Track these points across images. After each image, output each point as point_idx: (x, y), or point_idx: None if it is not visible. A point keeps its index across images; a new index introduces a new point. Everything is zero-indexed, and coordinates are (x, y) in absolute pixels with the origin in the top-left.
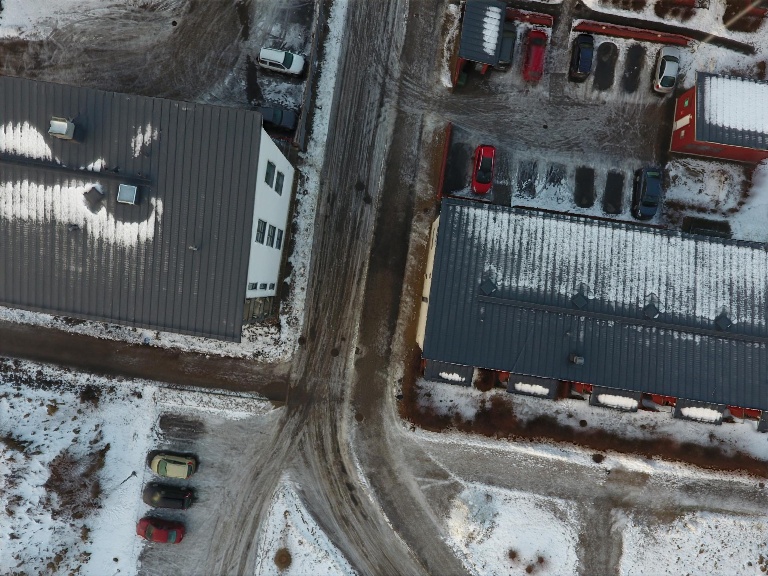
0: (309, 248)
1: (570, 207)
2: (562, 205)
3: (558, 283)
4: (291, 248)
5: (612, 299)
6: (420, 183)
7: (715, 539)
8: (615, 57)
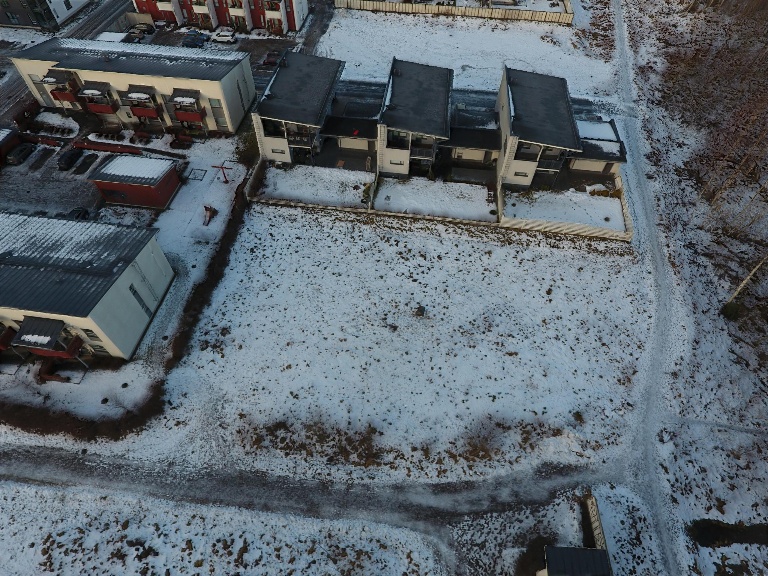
0: None
1: None
2: None
3: None
4: None
5: None
6: None
7: (5, 514)
8: (95, 160)
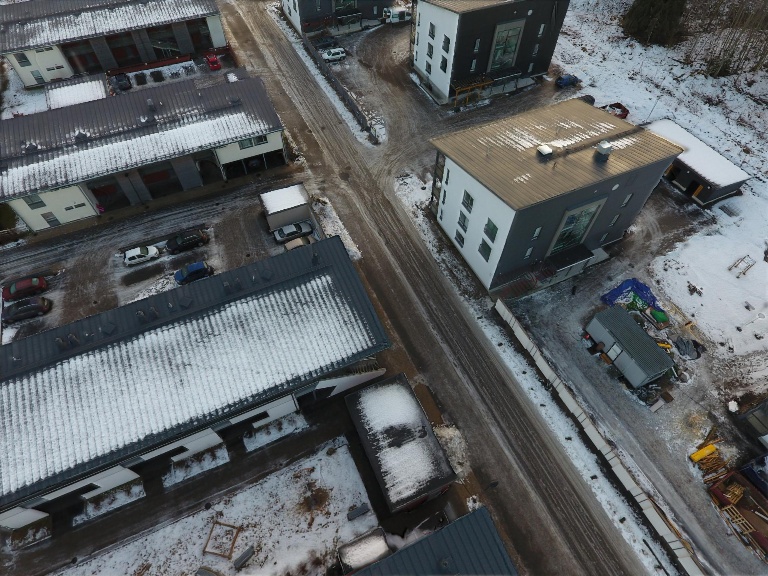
0: (280, 26)
1: (162, 69)
2: (167, 68)
3: (156, 4)
4: (288, 23)
5: (130, 6)
6: (242, 53)
7: None
8: None
